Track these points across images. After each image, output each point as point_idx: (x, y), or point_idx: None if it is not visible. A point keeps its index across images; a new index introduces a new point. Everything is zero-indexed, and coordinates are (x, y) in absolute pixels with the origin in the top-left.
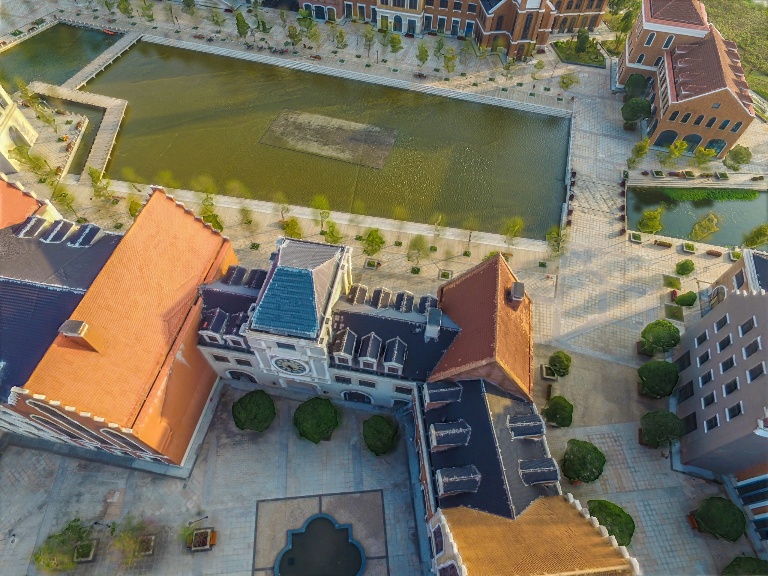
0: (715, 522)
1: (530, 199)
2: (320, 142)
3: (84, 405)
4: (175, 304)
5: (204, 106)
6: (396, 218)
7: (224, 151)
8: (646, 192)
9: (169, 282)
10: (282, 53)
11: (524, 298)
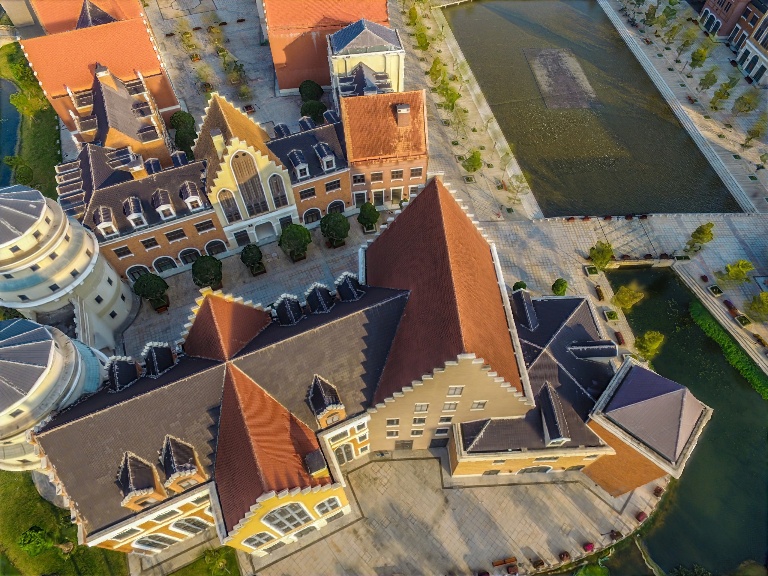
0: None
1: (589, 199)
2: (549, 73)
3: (268, 4)
4: (335, 15)
5: (537, 17)
6: (502, 127)
7: (501, 39)
8: (679, 287)
9: (343, 5)
10: (633, 25)
11: (422, 143)
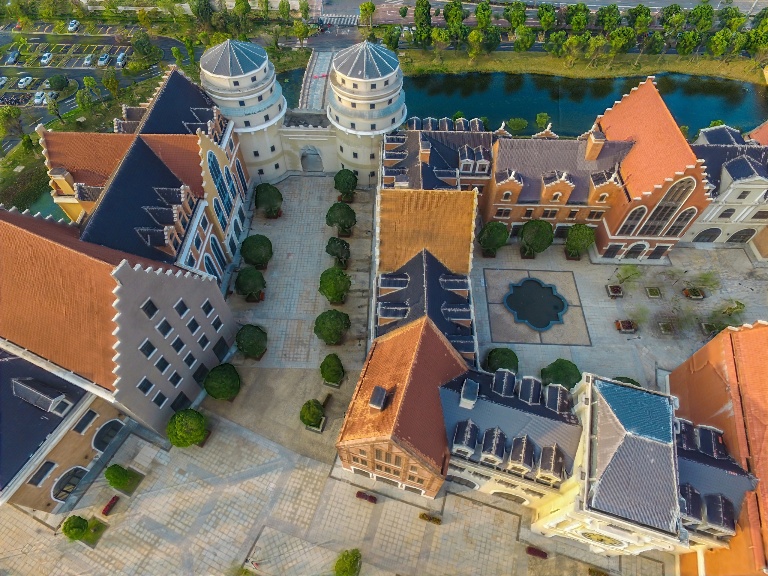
0: (260, 275)
1: None
2: None
3: None
4: None
5: None
6: None
7: None
8: None
9: None
10: None
11: (350, 437)
